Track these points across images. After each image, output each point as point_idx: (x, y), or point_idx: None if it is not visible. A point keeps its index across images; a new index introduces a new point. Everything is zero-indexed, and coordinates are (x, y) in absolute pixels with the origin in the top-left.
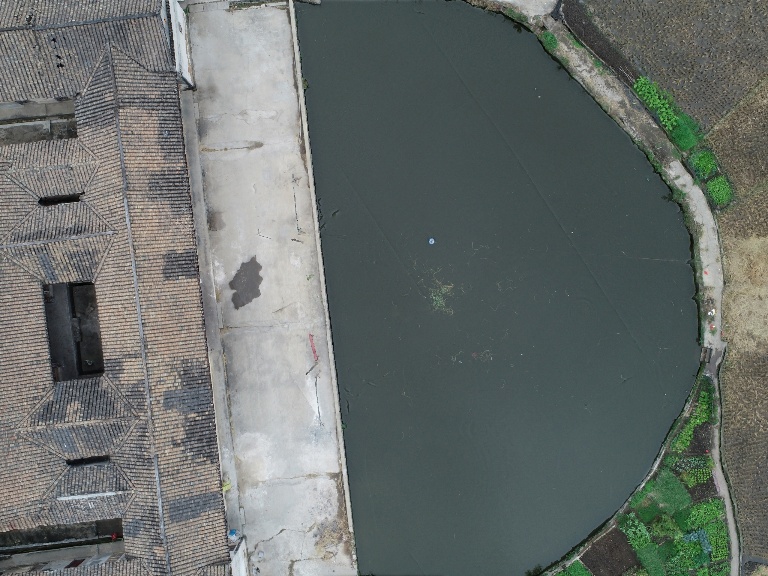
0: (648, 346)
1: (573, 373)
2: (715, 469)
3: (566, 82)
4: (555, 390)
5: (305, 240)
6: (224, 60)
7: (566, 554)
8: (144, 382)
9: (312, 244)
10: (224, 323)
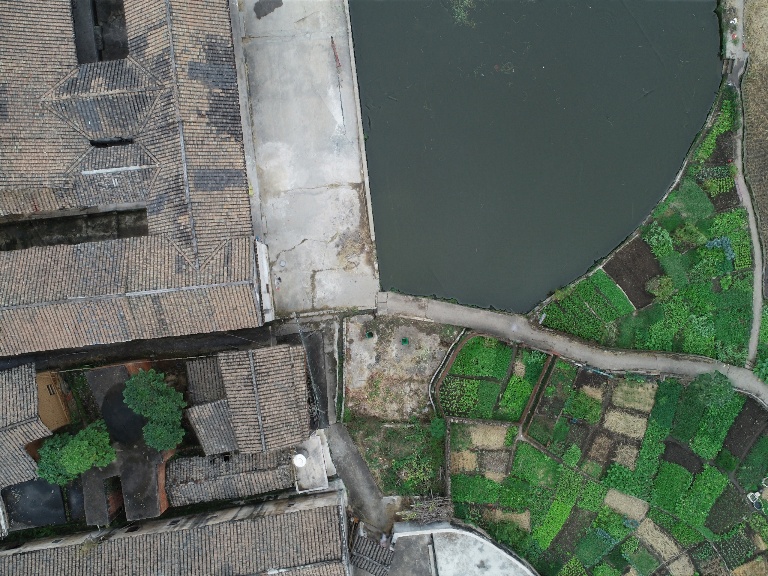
0: (670, 58)
1: (595, 86)
2: (738, 175)
3: None
4: (577, 103)
5: None
6: None
7: (588, 268)
8: (169, 49)
9: None
10: (246, 33)
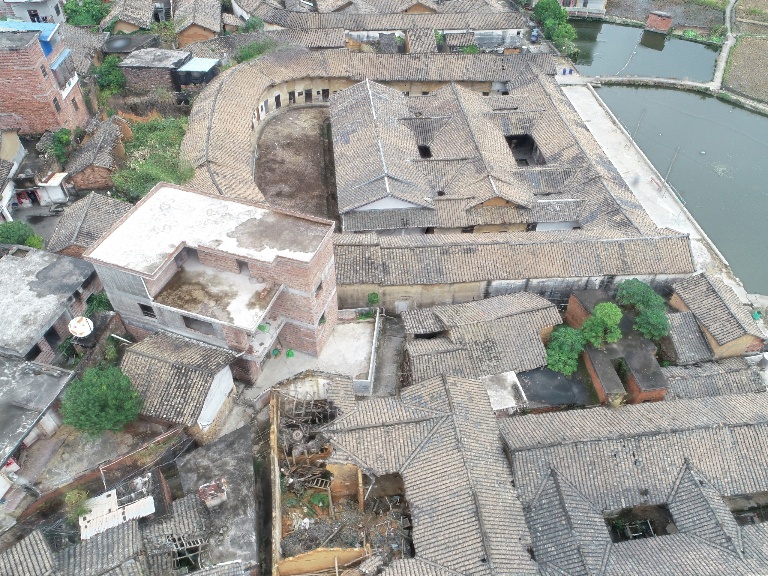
0: None
1: None
2: None
3: (740, 113)
4: None
5: (629, 149)
6: None
7: None
8: (581, 152)
9: (634, 151)
10: None
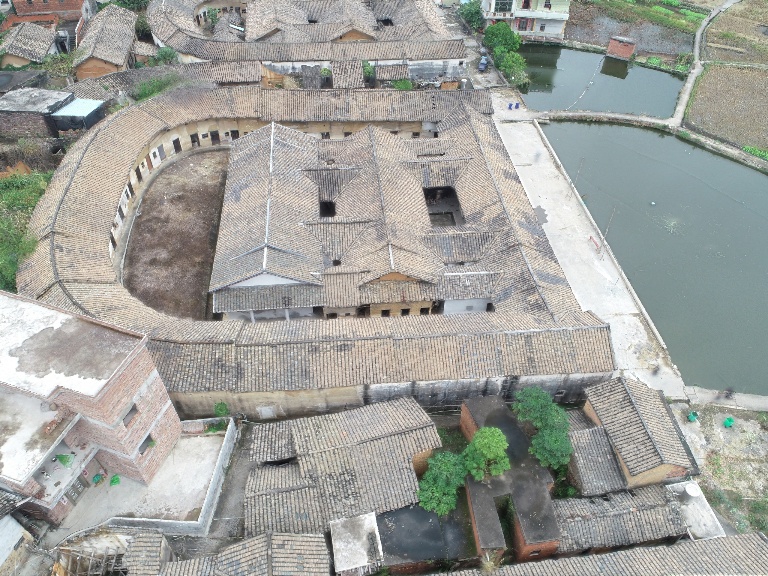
0: None
1: None
2: None
3: (701, 154)
4: None
5: (571, 200)
6: (502, 137)
7: None
8: (504, 212)
9: (576, 202)
10: None
